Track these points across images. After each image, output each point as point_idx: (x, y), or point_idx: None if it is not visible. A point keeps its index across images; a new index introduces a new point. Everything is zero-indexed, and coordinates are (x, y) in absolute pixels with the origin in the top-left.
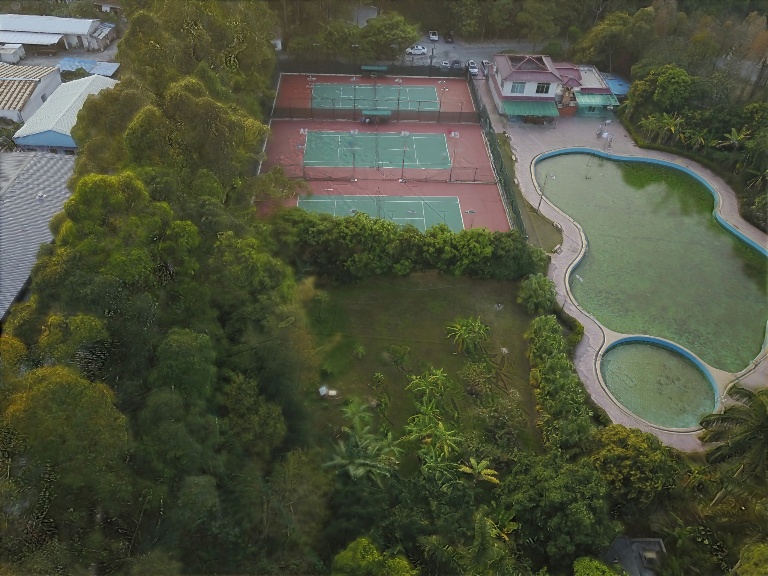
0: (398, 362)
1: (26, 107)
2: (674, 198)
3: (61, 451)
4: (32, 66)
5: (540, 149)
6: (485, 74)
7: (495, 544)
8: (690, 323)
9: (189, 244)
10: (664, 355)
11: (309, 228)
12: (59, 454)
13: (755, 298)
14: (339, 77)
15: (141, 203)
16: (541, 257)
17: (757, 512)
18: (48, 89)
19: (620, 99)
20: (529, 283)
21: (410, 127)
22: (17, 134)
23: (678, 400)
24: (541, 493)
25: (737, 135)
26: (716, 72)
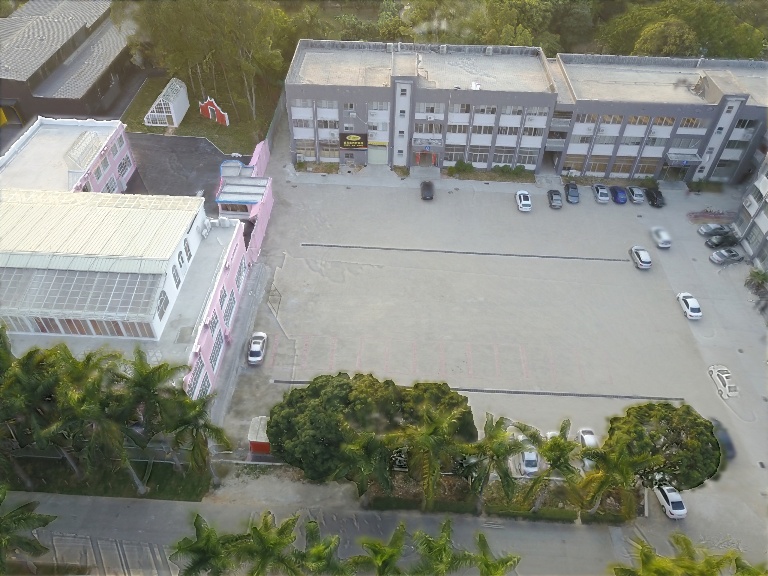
0: None
1: None
2: None
3: None
4: None
5: None
6: None
7: (325, 34)
8: None
9: None
10: None
11: None
12: None
13: None
14: None
15: None
16: None
17: None
18: None
19: None
20: (382, 3)
21: None
22: None
23: None
24: None
25: None
26: None
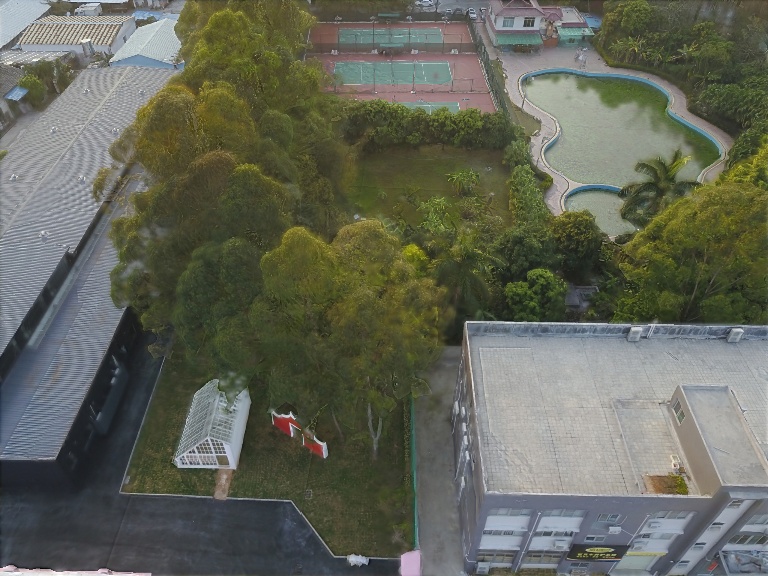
0: (411, 201)
1: (114, 44)
2: (635, 101)
3: (224, 132)
4: (113, 16)
5: (527, 70)
6: (483, 18)
7: None
8: (638, 178)
9: (274, 64)
10: (615, 197)
11: (343, 107)
12: (223, 133)
13: (692, 162)
14: (359, 24)
15: (247, 32)
16: (521, 131)
17: (640, 218)
18: (127, 32)
19: (596, 32)
20: (510, 147)
21: (419, 57)
22: (112, 60)
23: (622, 222)
24: (508, 240)
25: (688, 49)
26: (672, 2)
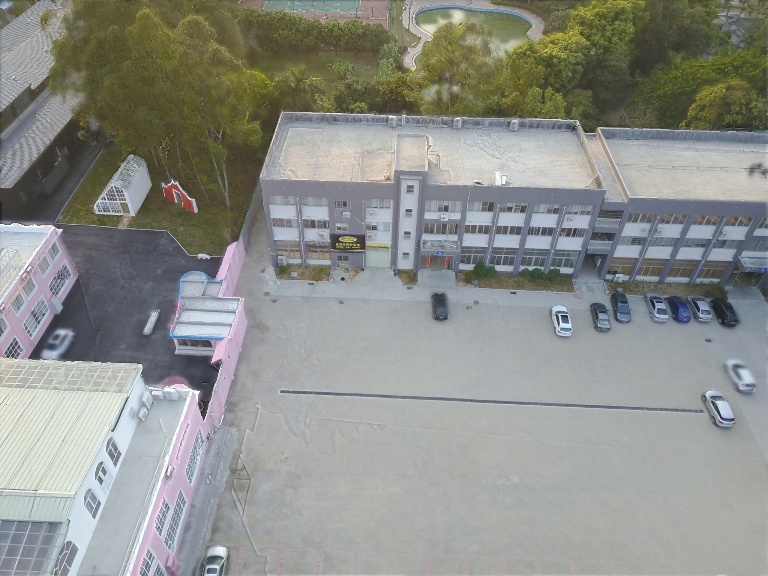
0: None
1: None
2: (505, 28)
3: None
4: None
5: (424, 5)
6: None
7: (315, 97)
8: None
9: None
10: None
11: (253, 14)
12: None
13: None
14: None
15: None
16: (395, 39)
17: None
18: None
19: None
20: (383, 48)
21: None
22: None
23: None
24: None
25: None
26: None
